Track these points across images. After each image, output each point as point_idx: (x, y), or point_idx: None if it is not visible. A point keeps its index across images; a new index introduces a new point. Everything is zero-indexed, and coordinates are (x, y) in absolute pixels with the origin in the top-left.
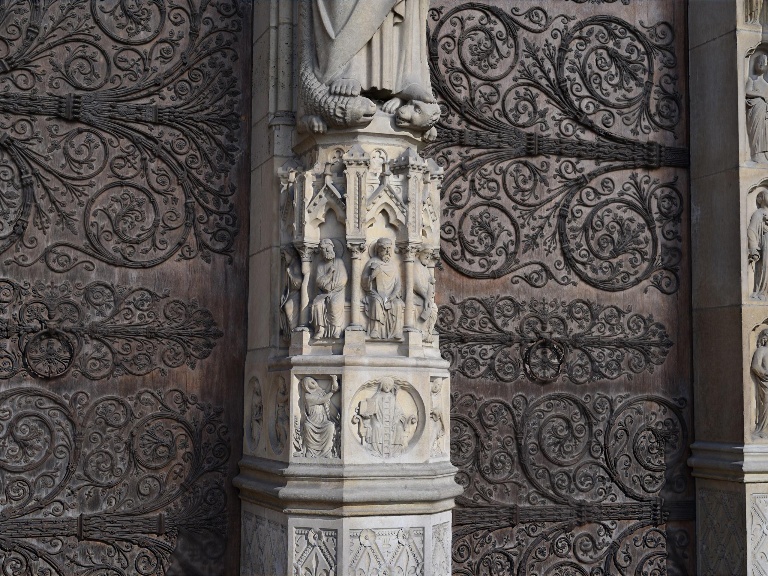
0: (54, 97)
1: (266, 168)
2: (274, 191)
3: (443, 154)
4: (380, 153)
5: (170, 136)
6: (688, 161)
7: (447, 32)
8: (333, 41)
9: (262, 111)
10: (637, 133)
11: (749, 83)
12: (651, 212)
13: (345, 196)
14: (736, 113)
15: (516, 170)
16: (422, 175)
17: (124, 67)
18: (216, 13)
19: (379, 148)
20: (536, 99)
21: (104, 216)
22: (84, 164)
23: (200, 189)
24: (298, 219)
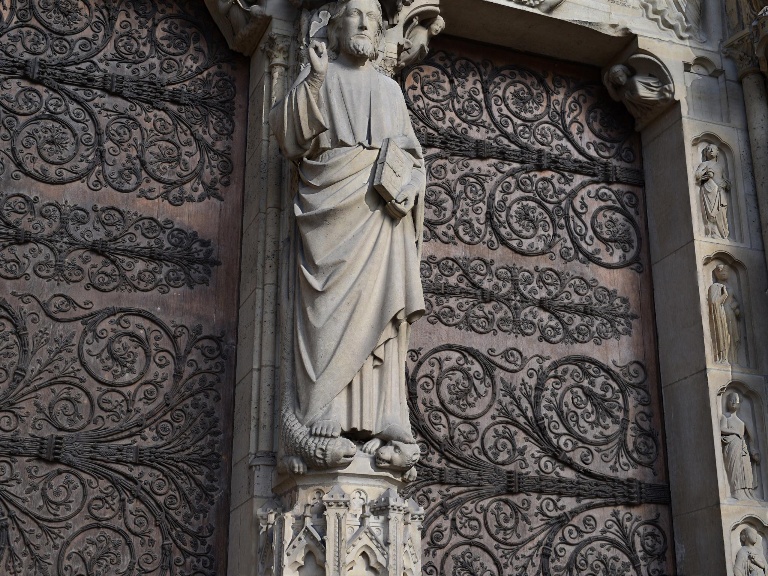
0: (36, 438)
1: (245, 509)
2: (253, 533)
3: (423, 492)
4: (360, 494)
5: (150, 476)
6: (669, 498)
7: (426, 372)
8: (314, 383)
9: (243, 451)
10: (616, 470)
11: (723, 420)
12: (635, 550)
13: (325, 538)
14: (713, 450)
15: (497, 508)
16: (402, 516)
17: (107, 408)
18: (200, 355)
19: (359, 489)
20: (515, 437)
21: (78, 559)
22: (61, 505)
23: (178, 530)
24: (277, 562)
